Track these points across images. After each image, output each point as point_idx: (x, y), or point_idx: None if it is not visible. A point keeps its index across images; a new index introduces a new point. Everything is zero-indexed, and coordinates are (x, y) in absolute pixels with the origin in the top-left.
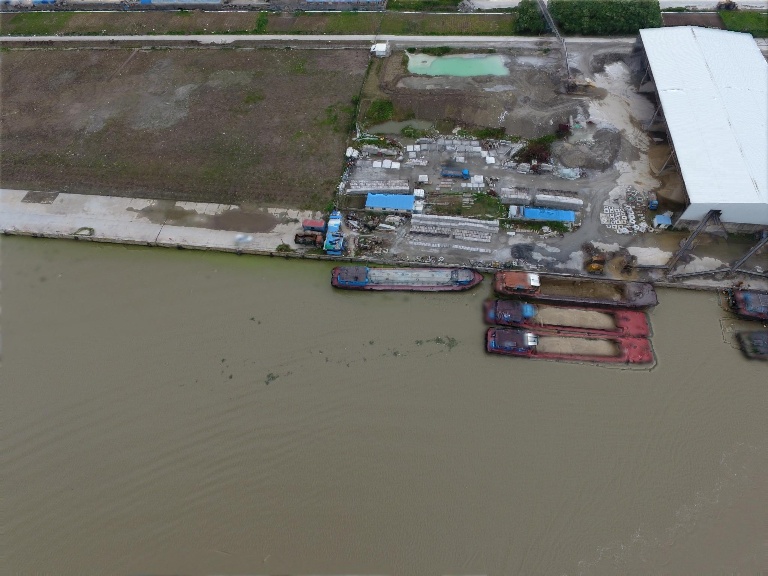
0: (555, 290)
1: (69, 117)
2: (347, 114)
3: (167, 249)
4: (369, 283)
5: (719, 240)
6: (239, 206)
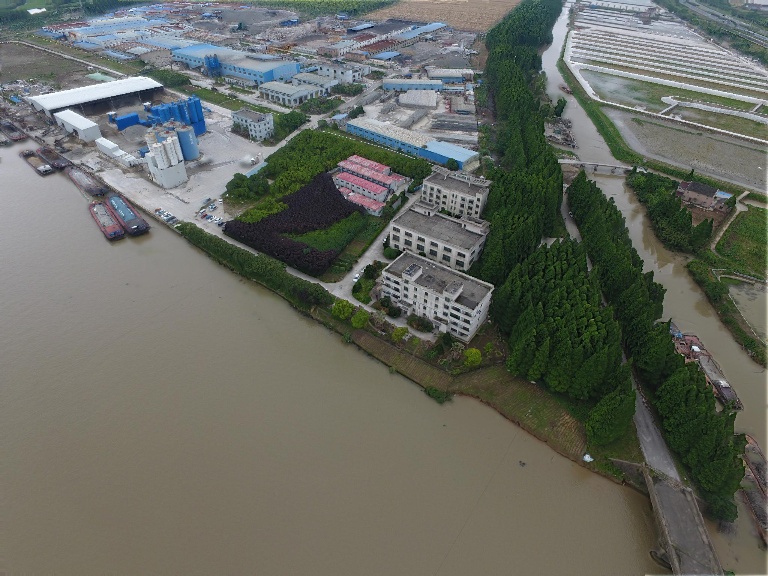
0: None
1: None
2: None
3: None
4: None
5: None
6: None
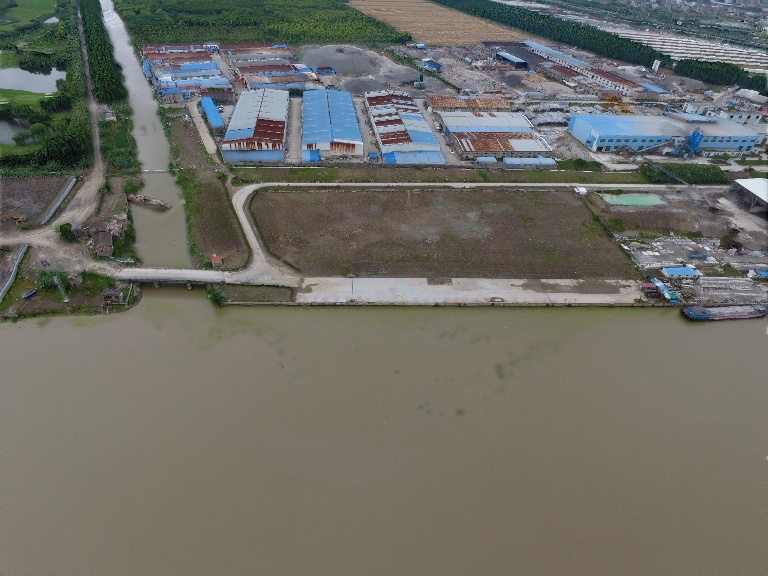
0: None
1: (406, 232)
2: (598, 227)
3: (563, 307)
4: (710, 316)
5: None
6: (584, 280)
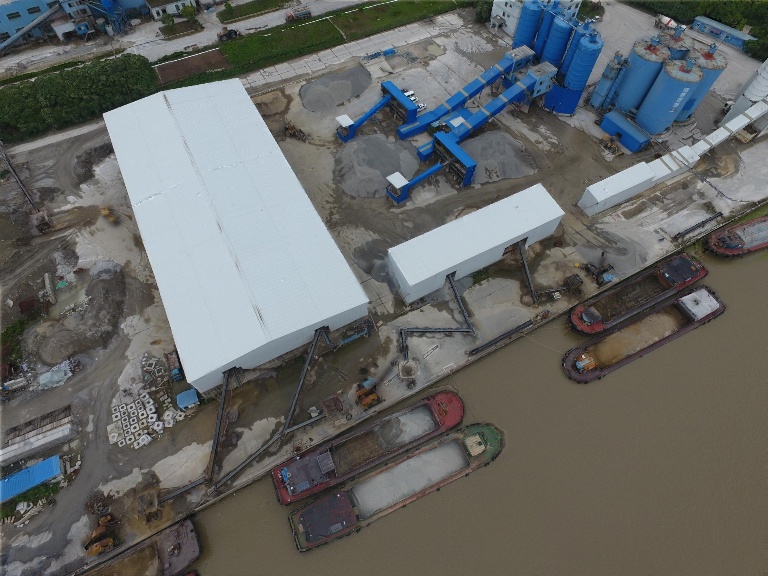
0: None
1: None
2: None
3: None
4: None
5: (267, 384)
6: None
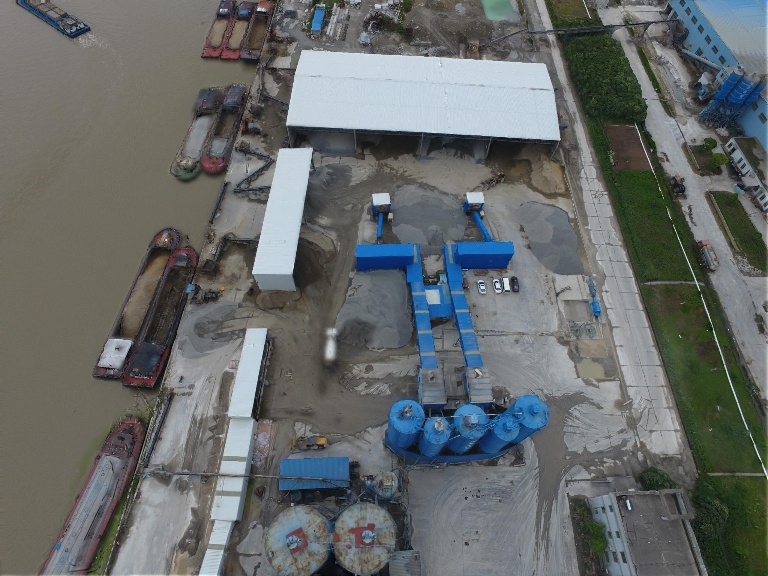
0: (263, 30)
1: None
2: None
3: None
4: None
5: None
6: None
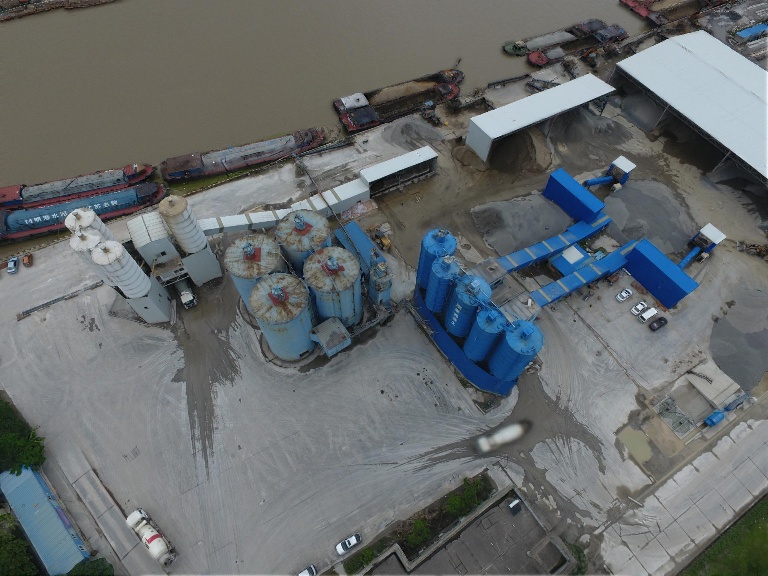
0: None
1: None
2: None
3: None
4: None
5: None
6: None
